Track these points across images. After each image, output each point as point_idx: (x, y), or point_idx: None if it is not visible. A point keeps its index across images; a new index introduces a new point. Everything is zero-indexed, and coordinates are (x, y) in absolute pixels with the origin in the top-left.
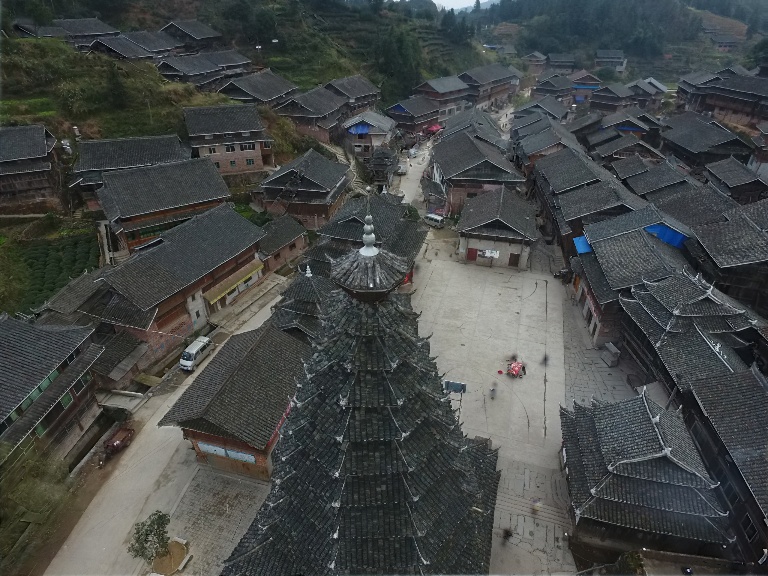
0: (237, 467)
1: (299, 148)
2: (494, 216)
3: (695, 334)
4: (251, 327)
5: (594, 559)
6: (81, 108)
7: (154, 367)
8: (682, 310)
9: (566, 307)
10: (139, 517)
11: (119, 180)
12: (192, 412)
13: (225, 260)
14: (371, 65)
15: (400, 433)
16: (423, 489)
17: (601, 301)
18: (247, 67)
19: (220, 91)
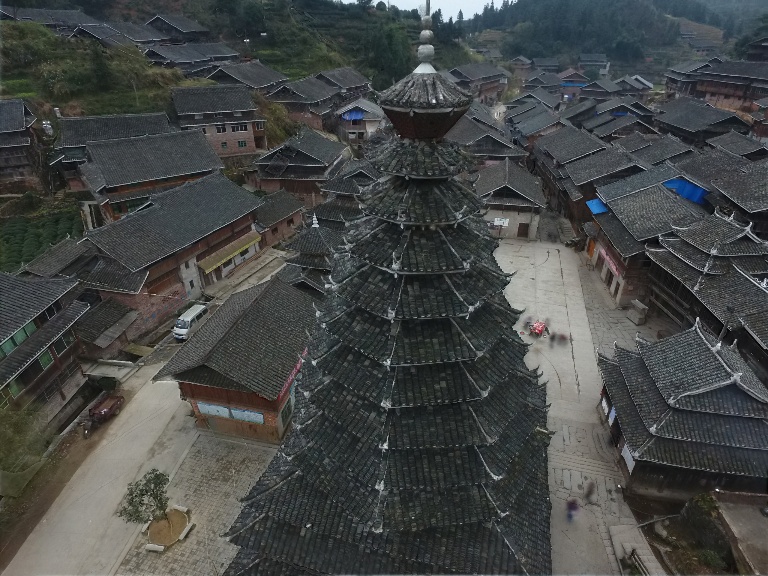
0: (243, 430)
1: (292, 134)
2: (502, 183)
3: (736, 274)
4: None
5: (653, 512)
6: (63, 89)
7: (145, 338)
8: (720, 250)
9: (582, 272)
10: None
11: (104, 150)
12: (192, 361)
13: (221, 225)
14: (361, 61)
15: (466, 307)
16: (491, 385)
17: (626, 254)
18: (235, 59)
19: (209, 78)
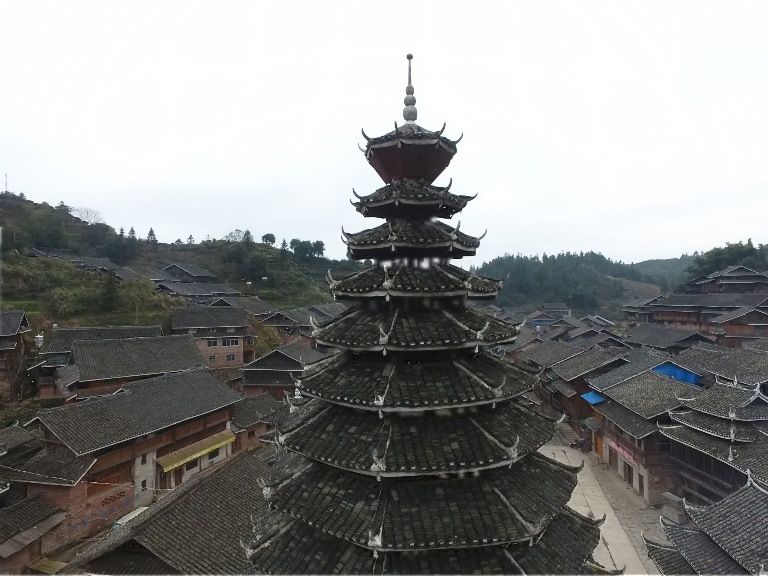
0: None
1: None
2: None
3: (767, 440)
4: None
5: None
6: (68, 309)
7: (64, 553)
8: (738, 414)
9: (596, 472)
10: None
11: (89, 348)
12: (117, 539)
13: (193, 415)
14: None
15: (473, 334)
16: None
17: (639, 435)
18: None
19: None
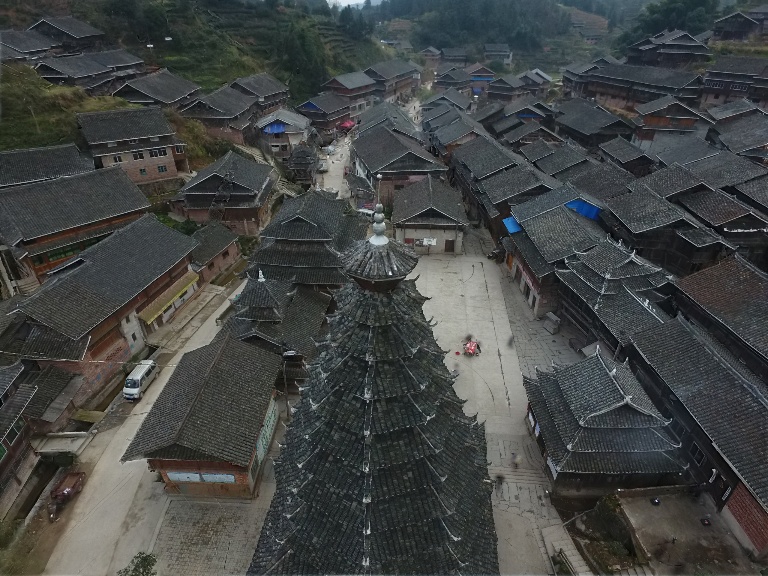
0: (214, 490)
1: (213, 151)
2: (427, 205)
3: (625, 294)
4: (196, 343)
5: (574, 509)
6: None
7: (92, 401)
8: (612, 274)
9: (504, 285)
10: (111, 566)
11: (14, 198)
12: (161, 440)
13: (159, 275)
14: (274, 63)
15: (424, 417)
16: (447, 469)
17: (539, 275)
18: (140, 68)
19: (115, 94)
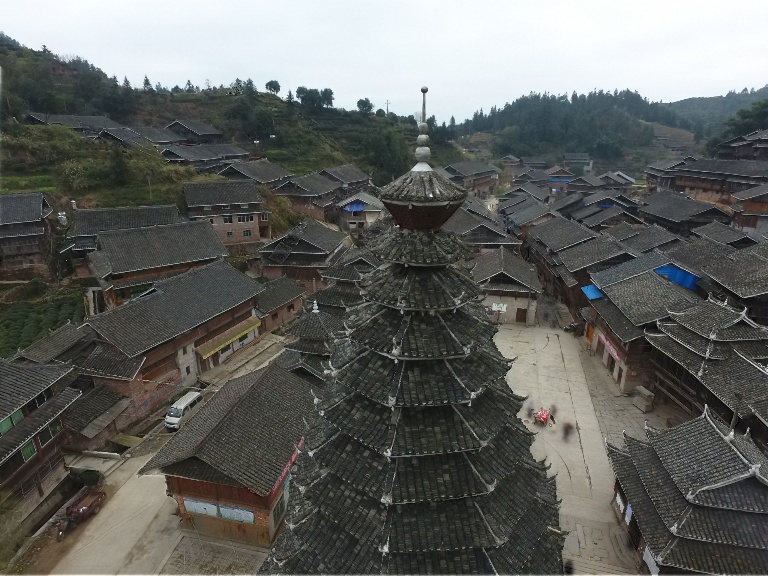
0: (231, 531)
1: (295, 224)
2: (498, 270)
3: (738, 359)
4: None
5: None
6: (81, 184)
7: (135, 427)
8: (719, 335)
9: (583, 358)
10: None
11: (114, 239)
12: (182, 452)
13: (222, 311)
14: (361, 159)
15: (468, 393)
16: (497, 478)
17: (625, 339)
18: (245, 158)
19: (219, 174)
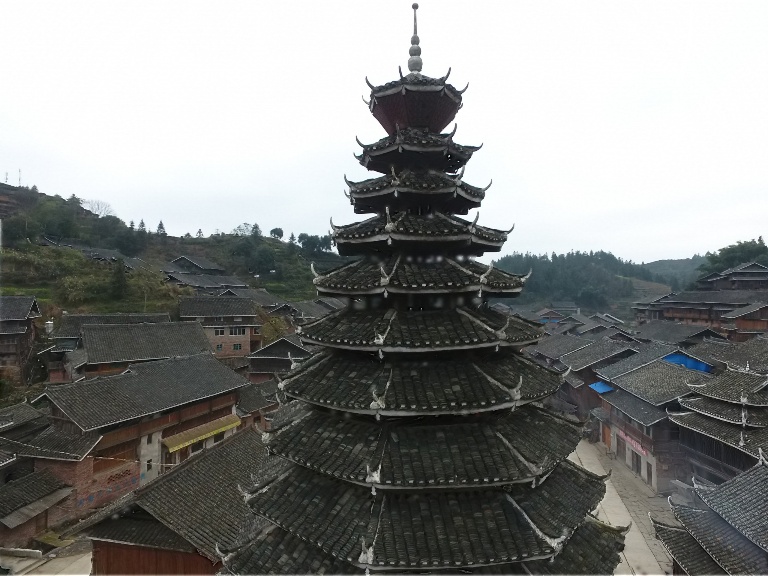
0: None
1: None
2: None
3: None
4: None
5: None
6: (77, 296)
7: (70, 527)
8: (750, 399)
9: (604, 461)
10: None
11: (97, 332)
12: None
13: (199, 397)
14: None
15: (476, 277)
16: None
17: (647, 422)
18: None
19: None
